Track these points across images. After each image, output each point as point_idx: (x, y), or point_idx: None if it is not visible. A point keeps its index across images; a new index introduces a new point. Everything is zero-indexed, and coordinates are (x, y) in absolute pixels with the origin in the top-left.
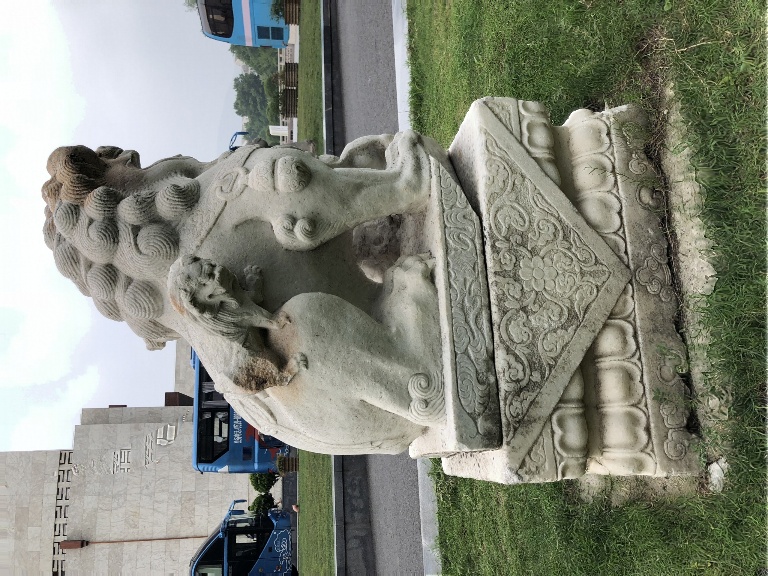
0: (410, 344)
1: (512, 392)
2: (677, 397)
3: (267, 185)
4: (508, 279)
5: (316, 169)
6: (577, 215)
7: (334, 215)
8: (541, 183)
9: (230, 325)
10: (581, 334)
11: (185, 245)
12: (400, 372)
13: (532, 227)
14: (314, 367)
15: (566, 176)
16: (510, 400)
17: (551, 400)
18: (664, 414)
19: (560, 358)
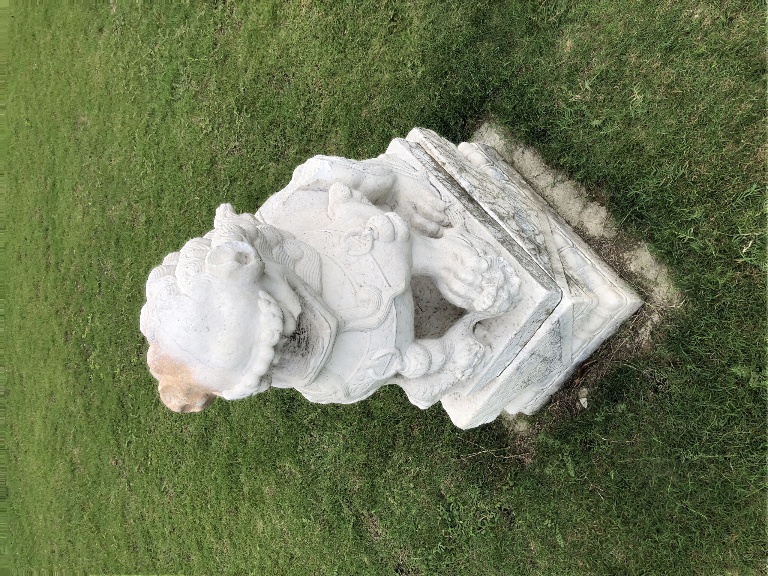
0: None
1: None
2: None
3: None
4: None
5: None
6: None
7: None
8: None
9: None
10: None
11: None
12: None
13: None
14: None
15: None
16: None
17: None
18: None
19: None
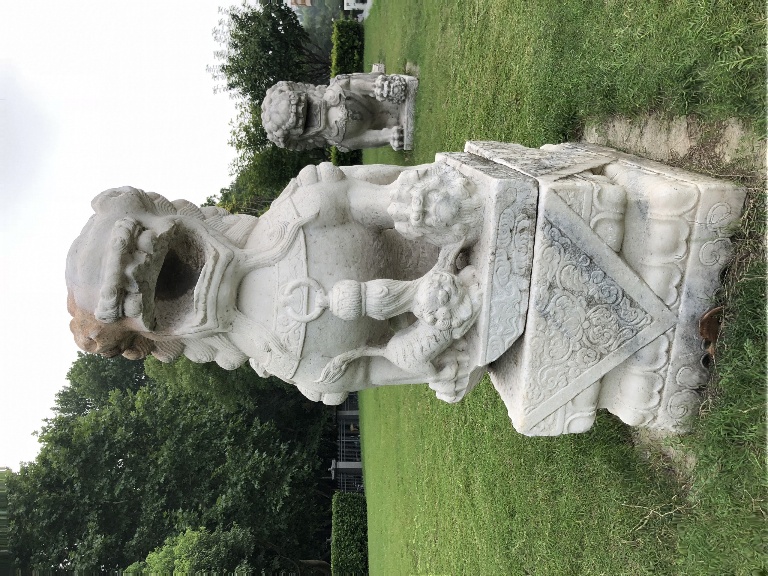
0: None
1: None
2: None
3: None
4: None
5: None
6: None
7: None
8: None
9: None
10: None
11: None
12: None
13: None
14: None
15: None
16: None
17: None
18: None
19: None
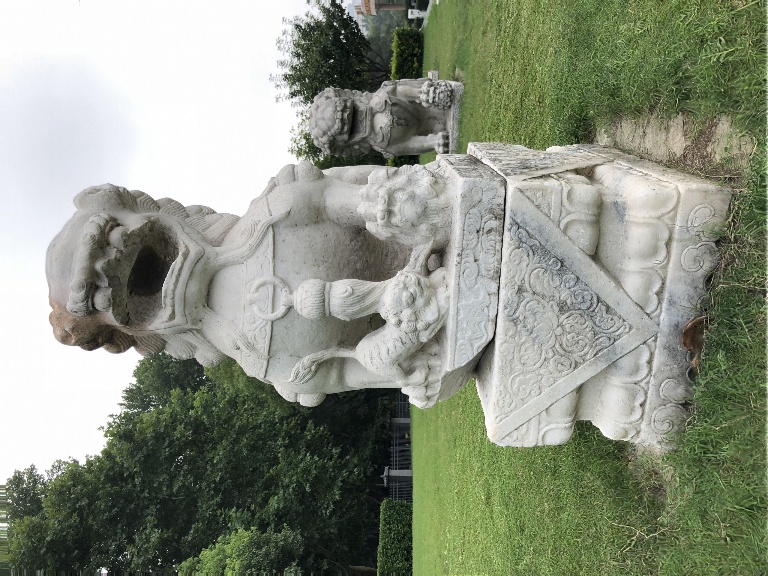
0: None
1: None
2: None
3: None
4: None
5: None
6: None
7: None
8: None
9: None
10: None
11: None
12: None
13: None
14: None
15: None
16: None
17: None
18: None
19: None
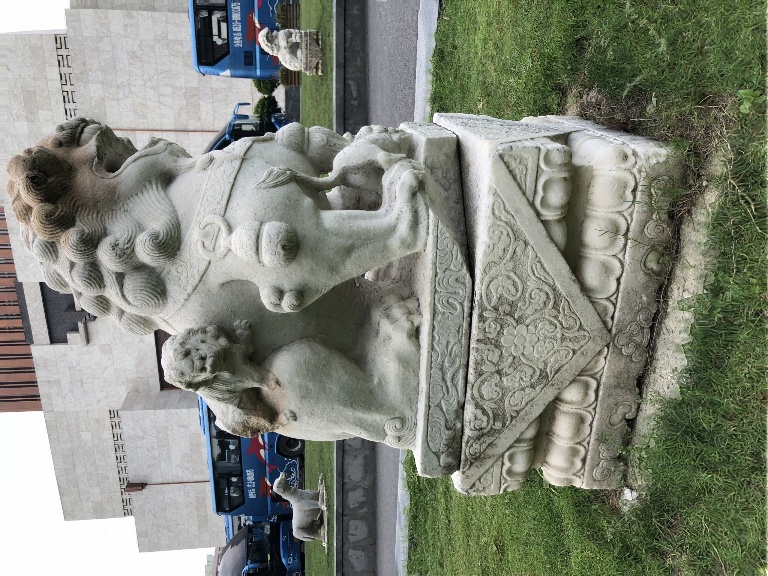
0: (390, 394)
1: (474, 437)
2: (618, 437)
3: (252, 260)
4: (489, 346)
5: (304, 233)
6: (573, 283)
7: (322, 282)
8: (544, 250)
9: (225, 392)
10: (547, 391)
11: (173, 295)
12: (378, 418)
13: (524, 296)
14: (302, 419)
15: (575, 226)
16: (471, 443)
17: (507, 443)
18: (602, 449)
19: (523, 411)
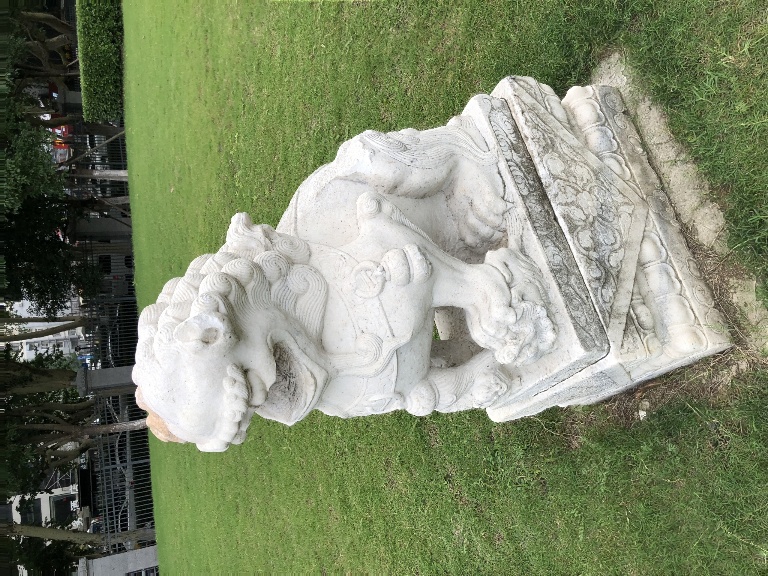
0: None
1: None
2: None
3: None
4: None
5: None
6: None
7: None
8: None
9: None
10: None
11: None
12: None
13: None
14: None
15: None
16: None
17: None
18: None
19: None
